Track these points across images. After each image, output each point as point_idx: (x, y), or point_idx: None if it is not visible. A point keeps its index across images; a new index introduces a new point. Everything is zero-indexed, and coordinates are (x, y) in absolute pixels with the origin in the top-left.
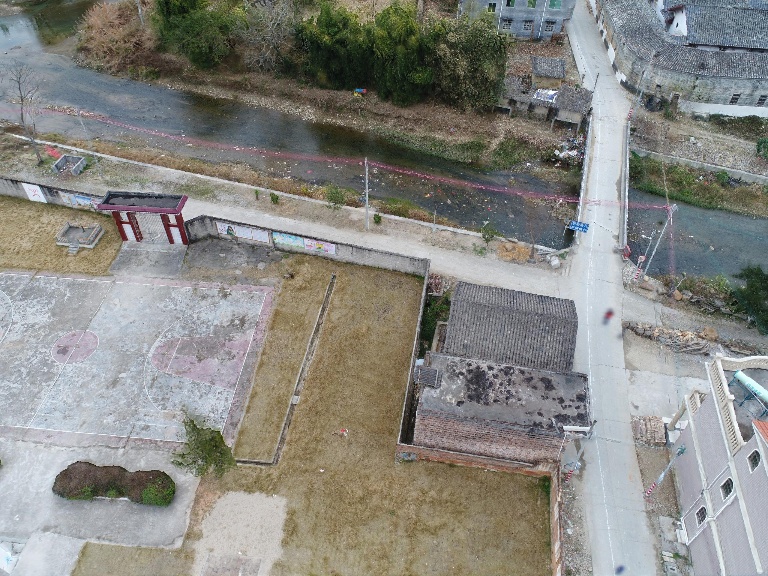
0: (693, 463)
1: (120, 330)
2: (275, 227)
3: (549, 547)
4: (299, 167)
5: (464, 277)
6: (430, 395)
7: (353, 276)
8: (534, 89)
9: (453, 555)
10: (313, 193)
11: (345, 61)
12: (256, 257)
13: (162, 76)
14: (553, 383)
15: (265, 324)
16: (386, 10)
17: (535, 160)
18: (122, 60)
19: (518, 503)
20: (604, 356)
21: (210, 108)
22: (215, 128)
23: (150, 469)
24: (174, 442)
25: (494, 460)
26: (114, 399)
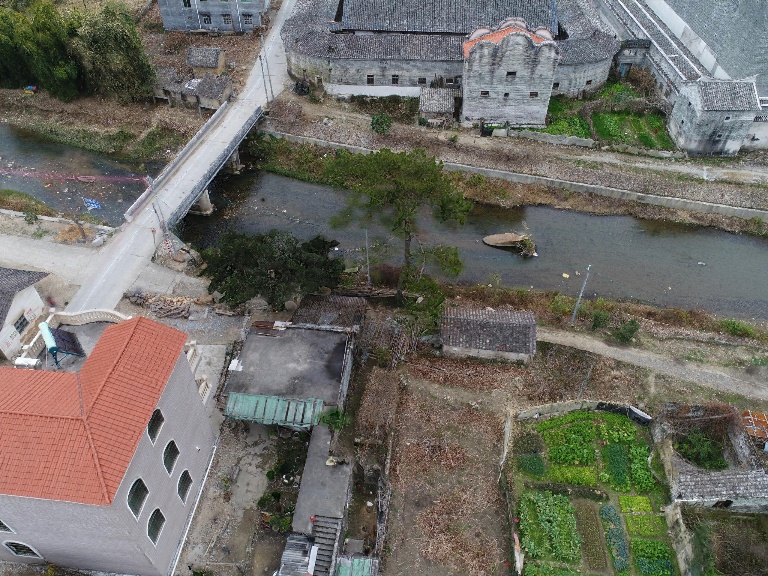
0: None
1: None
2: None
3: None
4: None
5: (5, 260)
6: None
7: None
8: (189, 79)
9: None
10: None
11: (2, 59)
12: None
13: None
14: None
15: None
16: None
17: (177, 147)
18: None
19: None
20: None
21: None
22: None
23: None
24: None
25: None
26: None
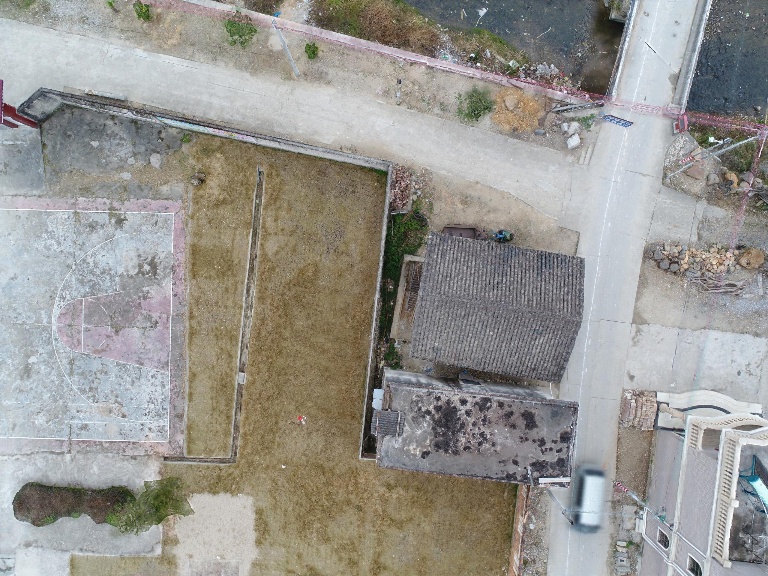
0: (672, 486)
1: (3, 292)
2: (158, 80)
3: (510, 539)
4: None
5: (442, 170)
6: (391, 446)
7: (287, 174)
8: None
9: (418, 548)
10: None
11: None
12: (144, 144)
13: None
14: (536, 419)
15: (183, 269)
16: None
17: None
18: None
19: (485, 496)
20: (610, 307)
21: None
22: None
23: (105, 475)
24: (120, 442)
25: None
26: (35, 393)
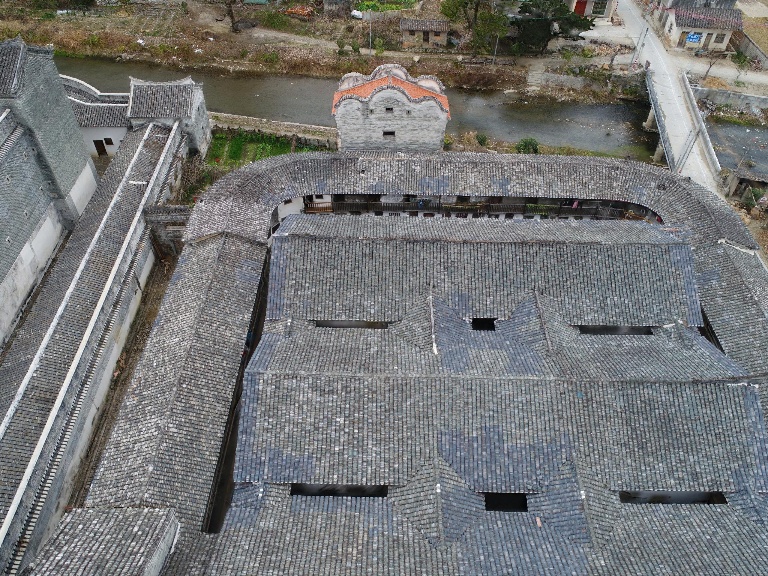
0: None
1: None
2: None
3: None
4: None
5: None
6: None
7: None
8: None
9: None
10: None
11: None
12: None
13: None
14: None
15: None
16: None
17: None
18: None
19: None
20: None
21: None
22: None
23: None
24: None
25: None
26: None
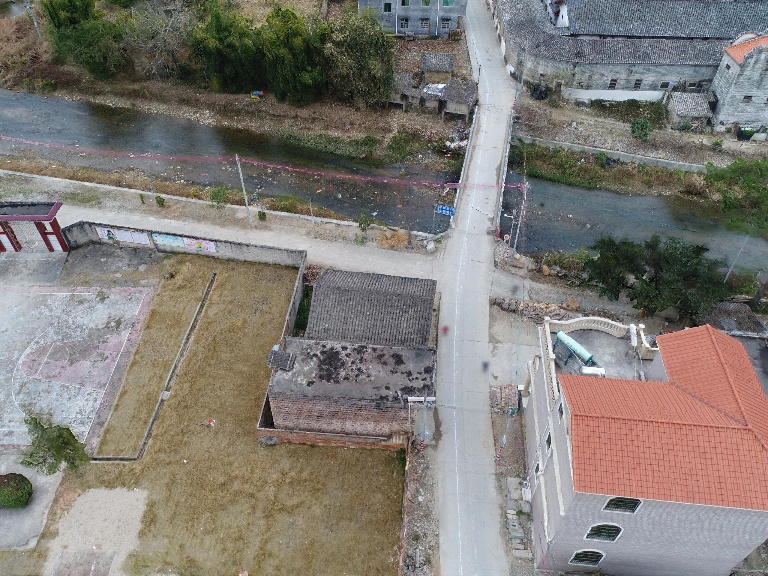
0: (534, 424)
1: None
2: (159, 229)
3: (400, 515)
4: (193, 170)
5: (343, 266)
6: (282, 378)
7: (234, 272)
8: (425, 83)
9: (307, 531)
10: (203, 195)
11: (238, 64)
12: (138, 260)
13: (59, 88)
14: (403, 358)
15: (141, 324)
16: (275, 13)
17: (427, 152)
18: (18, 74)
19: (375, 476)
20: (469, 332)
21: (107, 117)
22: (110, 137)
23: None
24: None
25: (350, 437)
26: None
